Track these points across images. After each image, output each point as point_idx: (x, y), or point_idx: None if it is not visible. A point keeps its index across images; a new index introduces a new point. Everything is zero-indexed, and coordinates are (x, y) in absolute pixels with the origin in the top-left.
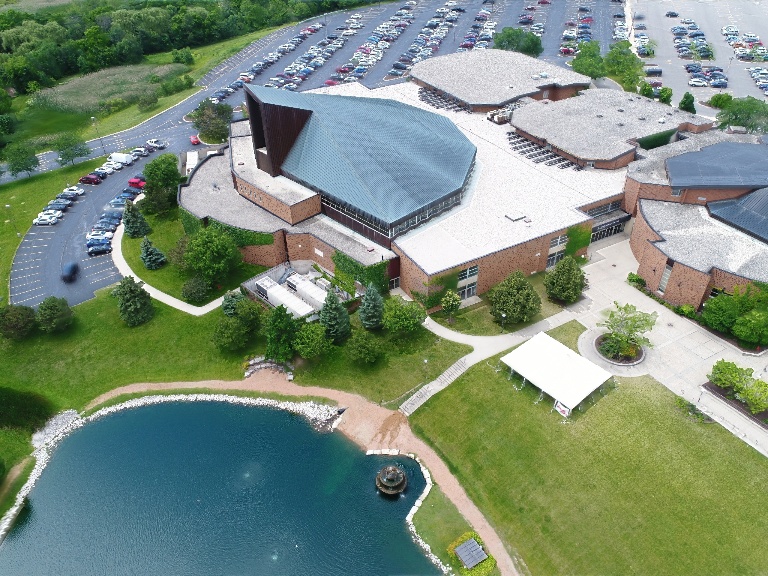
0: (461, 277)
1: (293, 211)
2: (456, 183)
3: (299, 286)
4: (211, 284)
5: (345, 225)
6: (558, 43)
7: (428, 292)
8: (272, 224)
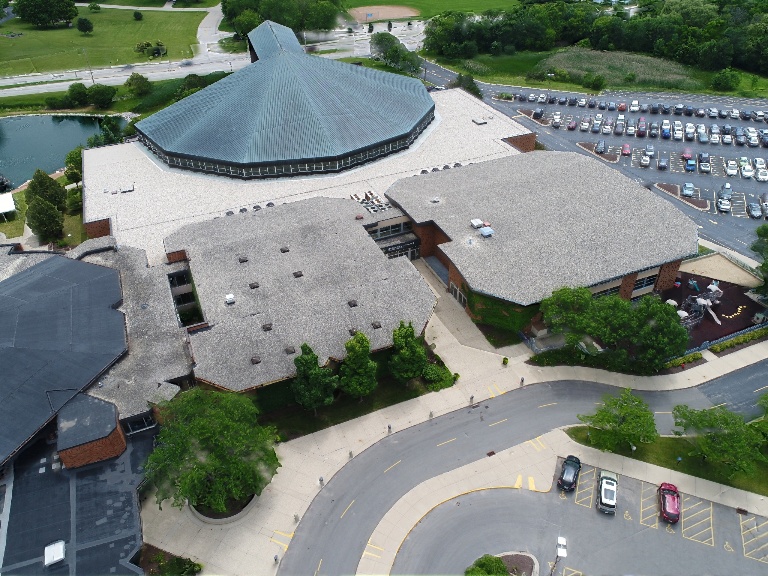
0: None
1: None
2: (169, 146)
3: None
4: None
5: None
6: None
7: None
8: None
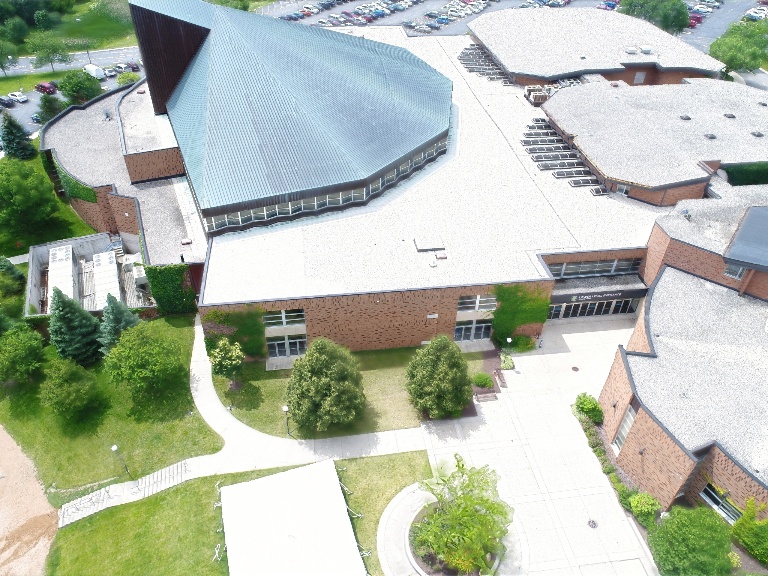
0: (271, 321)
1: (131, 163)
2: (359, 171)
3: (96, 269)
4: (15, 237)
5: (193, 199)
6: (731, 23)
7: (204, 331)
8: (112, 176)
